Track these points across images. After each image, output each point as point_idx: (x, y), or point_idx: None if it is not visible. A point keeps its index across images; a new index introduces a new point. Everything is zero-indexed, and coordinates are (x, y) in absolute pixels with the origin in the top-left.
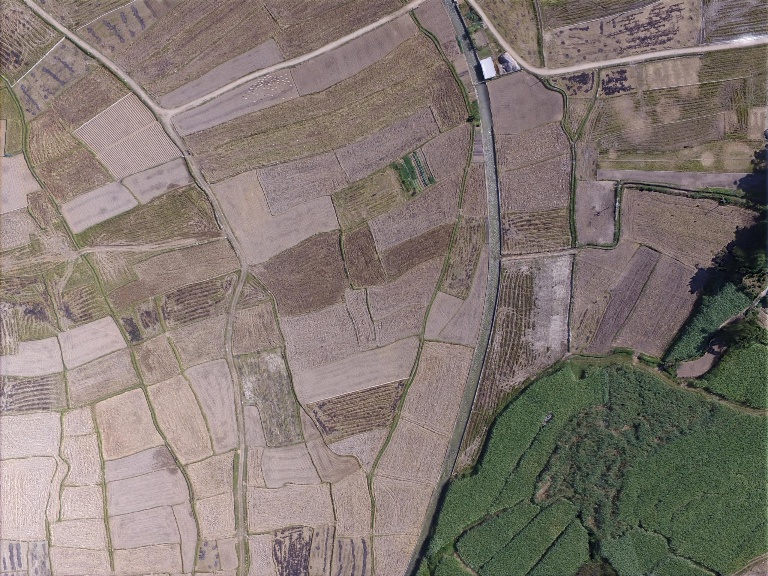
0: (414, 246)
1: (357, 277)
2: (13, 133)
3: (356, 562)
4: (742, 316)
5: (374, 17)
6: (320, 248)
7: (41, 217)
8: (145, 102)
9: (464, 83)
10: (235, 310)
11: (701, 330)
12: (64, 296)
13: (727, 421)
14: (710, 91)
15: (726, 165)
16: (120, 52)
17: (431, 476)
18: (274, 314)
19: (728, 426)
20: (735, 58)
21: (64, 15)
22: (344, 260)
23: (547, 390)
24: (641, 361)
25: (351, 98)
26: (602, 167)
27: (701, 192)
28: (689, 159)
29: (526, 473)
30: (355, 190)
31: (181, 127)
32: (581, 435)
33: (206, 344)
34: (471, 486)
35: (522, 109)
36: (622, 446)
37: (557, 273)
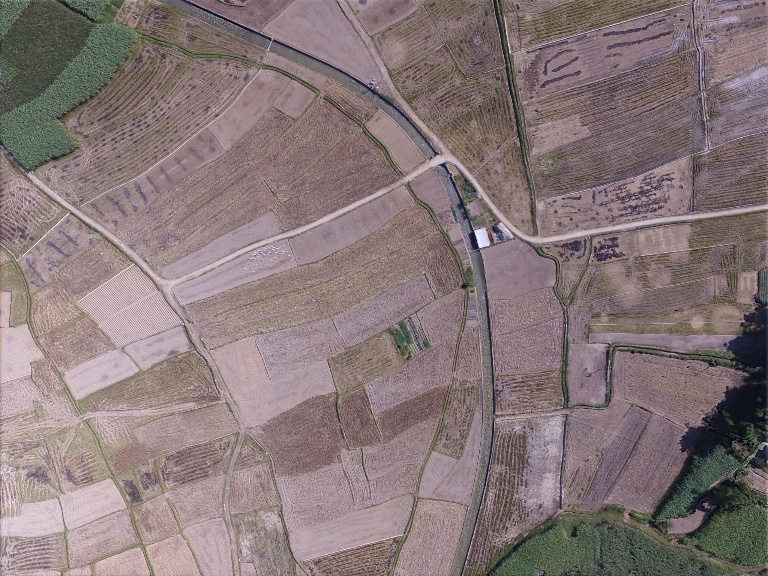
0: (409, 408)
1: (353, 438)
2: (18, 305)
3: None
4: (732, 478)
5: (371, 189)
6: (317, 410)
7: (44, 385)
8: (147, 273)
9: (459, 251)
10: (233, 471)
11: (691, 491)
12: (66, 460)
13: None
14: (700, 257)
15: (716, 328)
16: (123, 226)
17: None
18: (271, 474)
19: None
20: (725, 225)
21: (69, 192)
22: (340, 422)
23: (539, 548)
24: (632, 518)
25: (348, 267)
26: (594, 330)
27: (691, 354)
28: (680, 322)
29: None
30: (351, 355)
31: (182, 296)
32: None
33: (204, 504)
34: None
35: (516, 275)
36: None
37: (550, 432)
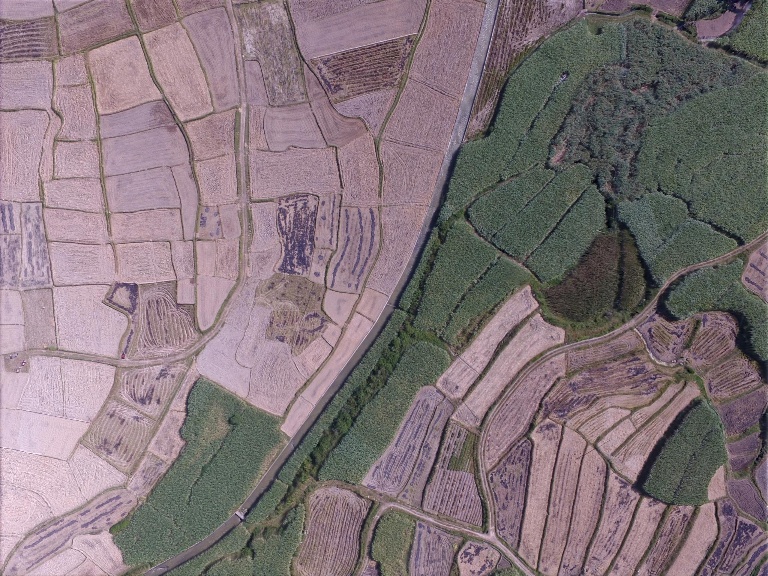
0: None
1: None
2: None
3: (364, 233)
4: None
5: None
6: None
7: None
8: None
9: None
10: None
11: None
12: None
13: (749, 78)
14: None
15: None
16: None
17: (441, 142)
18: None
19: (750, 83)
20: None
21: None
22: None
23: (562, 45)
24: (660, 19)
25: None
26: None
27: None
28: None
29: (540, 135)
30: None
31: None
32: (597, 94)
33: None
34: (483, 147)
35: None
36: (640, 104)
37: None
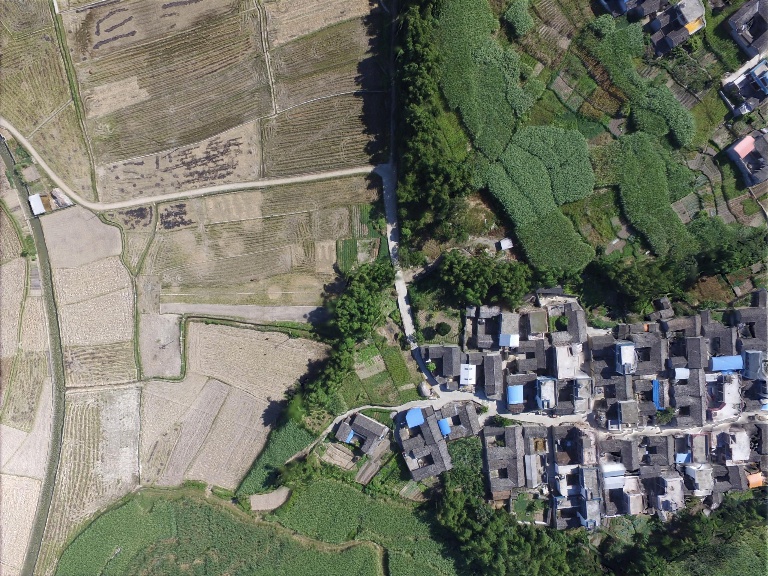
0: None
1: None
2: None
3: None
4: (304, 453)
5: None
6: None
7: None
8: None
9: (17, 218)
10: None
11: (265, 466)
12: None
13: (296, 557)
14: (274, 225)
15: (295, 298)
16: None
17: None
18: None
19: (296, 562)
20: (299, 192)
21: None
22: None
23: (112, 524)
24: (213, 494)
25: None
26: (165, 300)
27: (268, 326)
28: (255, 292)
29: None
30: None
31: None
32: (149, 569)
33: None
34: None
35: (79, 243)
36: None
37: (125, 405)
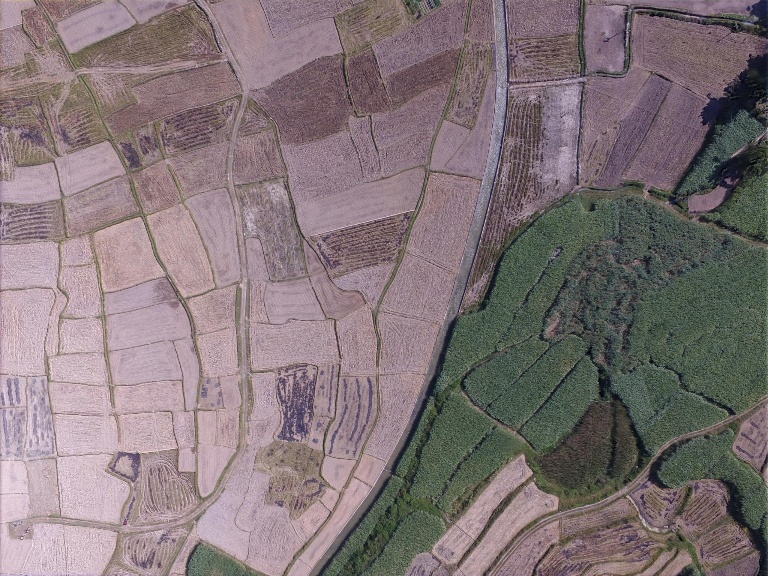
0: (419, 72)
1: (361, 104)
2: None
3: (362, 402)
4: (755, 143)
5: None
6: (323, 73)
7: (36, 35)
8: None
9: None
10: (236, 137)
11: (713, 159)
12: (61, 119)
13: (740, 254)
14: None
15: None
16: None
17: (438, 313)
18: (276, 142)
19: (741, 258)
20: None
21: None
22: (348, 86)
23: (556, 222)
24: (652, 194)
25: None
26: None
27: (713, 18)
28: None
29: (535, 308)
30: (359, 12)
31: None
32: (591, 269)
33: (207, 172)
34: (479, 321)
35: None
36: (633, 279)
37: (566, 102)
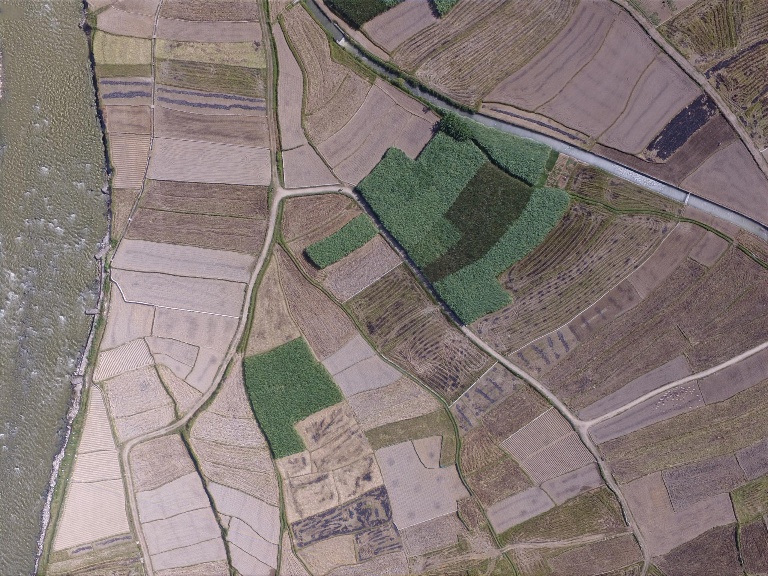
0: None
1: (751, 565)
2: (448, 447)
3: None
4: None
5: None
6: (717, 539)
7: (469, 520)
8: (565, 416)
9: None
10: None
11: None
12: None
13: None
14: None
15: None
16: (546, 373)
17: None
18: None
19: None
20: None
21: (498, 343)
22: (739, 550)
23: None
24: None
25: (753, 405)
26: None
27: None
28: None
29: None
30: (752, 487)
31: (596, 436)
32: None
33: None
34: None
35: None
36: None
37: None
